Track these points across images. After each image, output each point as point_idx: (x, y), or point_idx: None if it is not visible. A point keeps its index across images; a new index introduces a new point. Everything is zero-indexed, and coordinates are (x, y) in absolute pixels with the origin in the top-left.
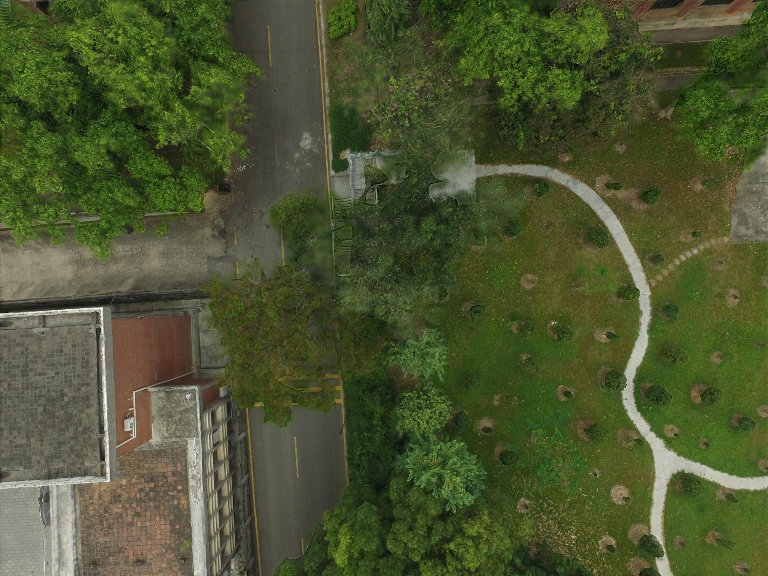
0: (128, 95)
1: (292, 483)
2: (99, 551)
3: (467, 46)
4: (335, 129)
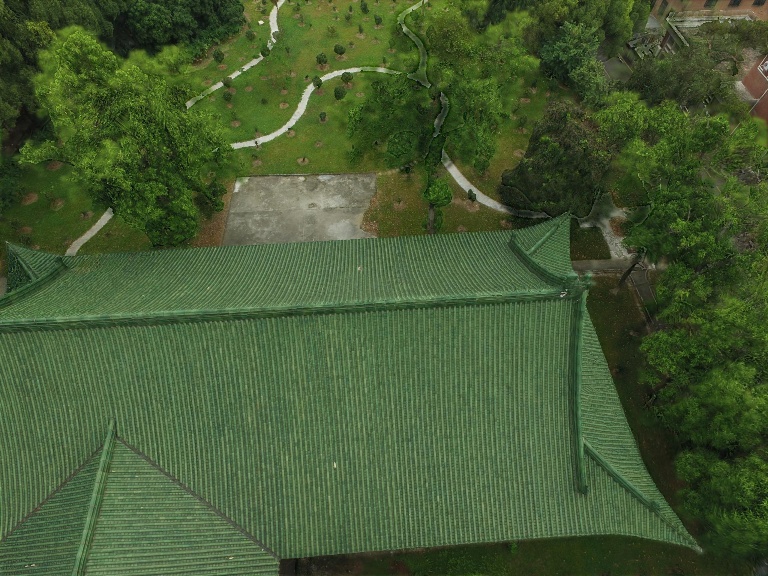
0: None
1: None
2: None
3: None
4: None
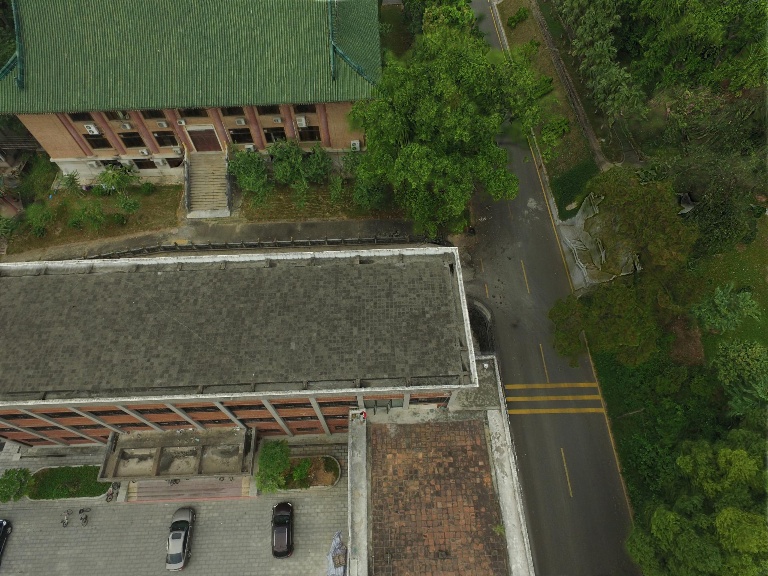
0: (503, 100)
1: (566, 503)
2: (394, 538)
3: (733, 75)
4: (559, 192)
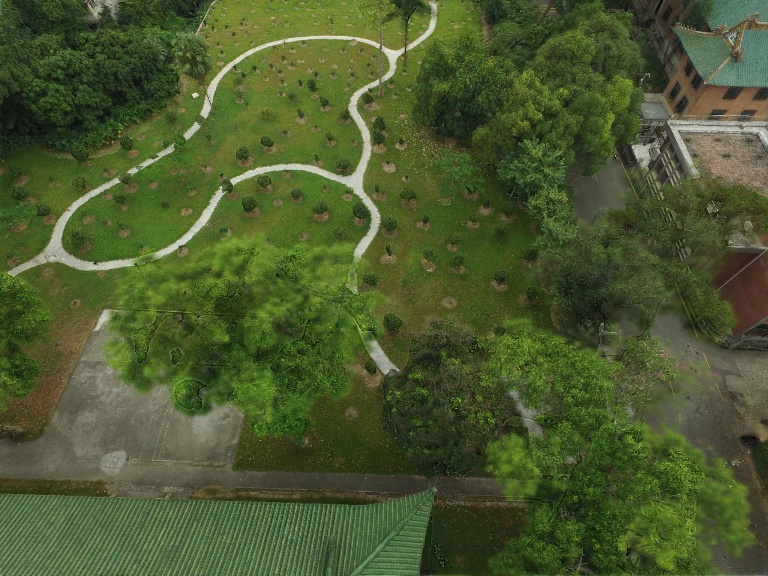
0: None
1: None
2: (759, 163)
3: None
4: None
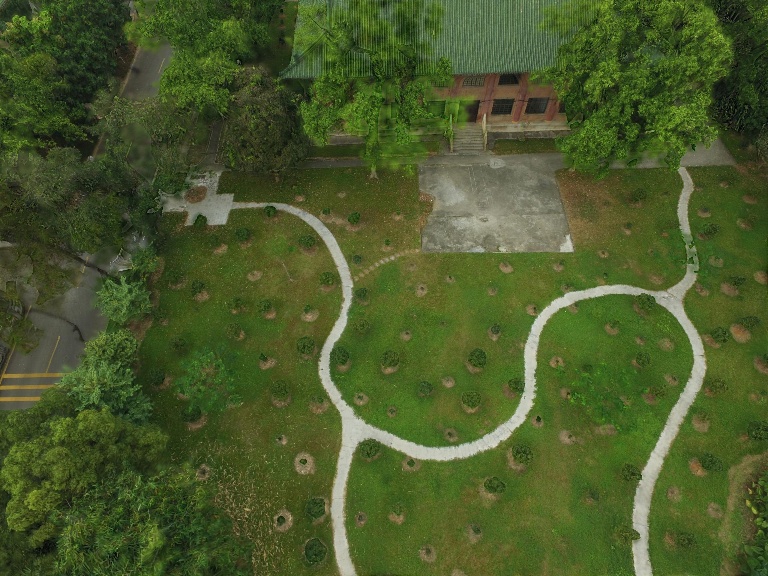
0: None
1: None
2: None
3: None
4: None
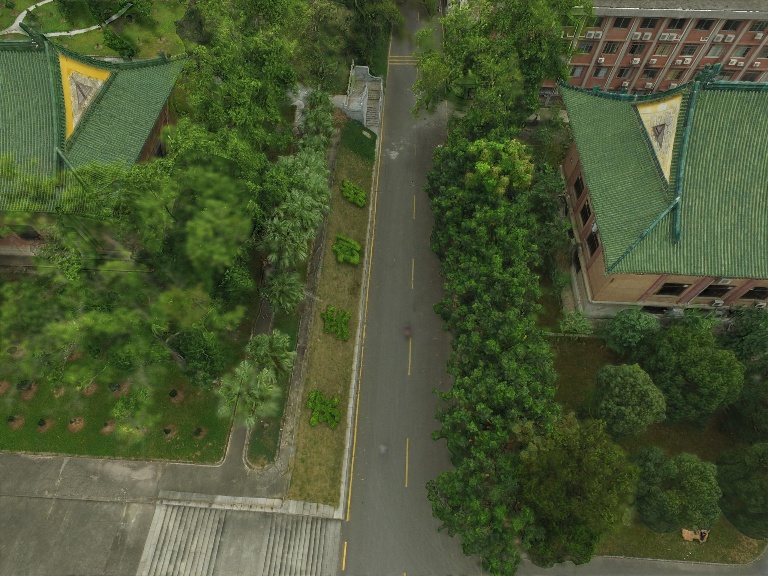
0: None
1: None
2: None
3: None
4: None
